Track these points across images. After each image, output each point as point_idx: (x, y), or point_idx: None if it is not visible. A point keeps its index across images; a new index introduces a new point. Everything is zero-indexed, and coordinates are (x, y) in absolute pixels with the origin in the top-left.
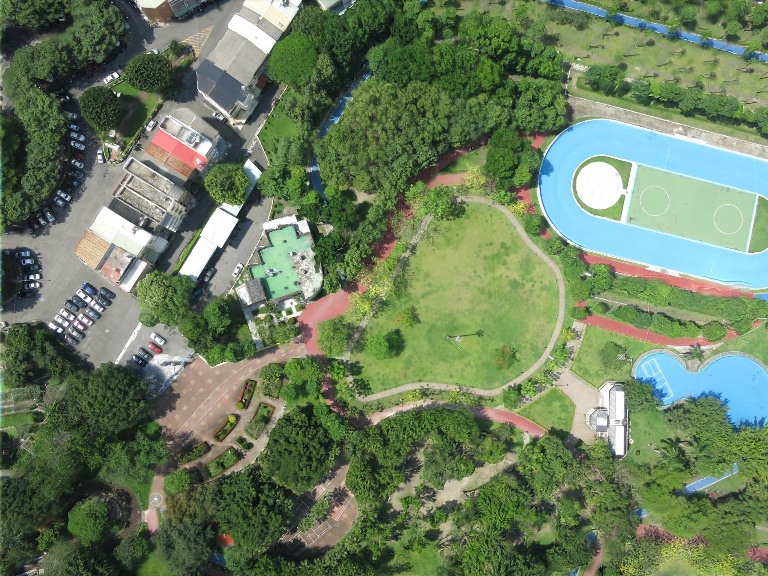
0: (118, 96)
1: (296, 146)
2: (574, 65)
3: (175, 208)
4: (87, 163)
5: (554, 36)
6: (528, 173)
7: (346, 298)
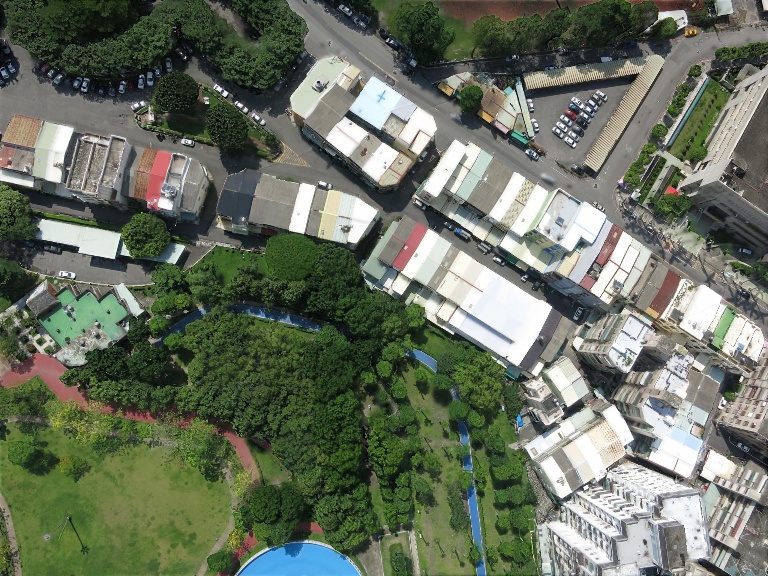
0: (205, 102)
1: (202, 291)
2: (413, 533)
3: (95, 196)
4: (127, 95)
5: (434, 501)
6: (264, 537)
7: (76, 394)
